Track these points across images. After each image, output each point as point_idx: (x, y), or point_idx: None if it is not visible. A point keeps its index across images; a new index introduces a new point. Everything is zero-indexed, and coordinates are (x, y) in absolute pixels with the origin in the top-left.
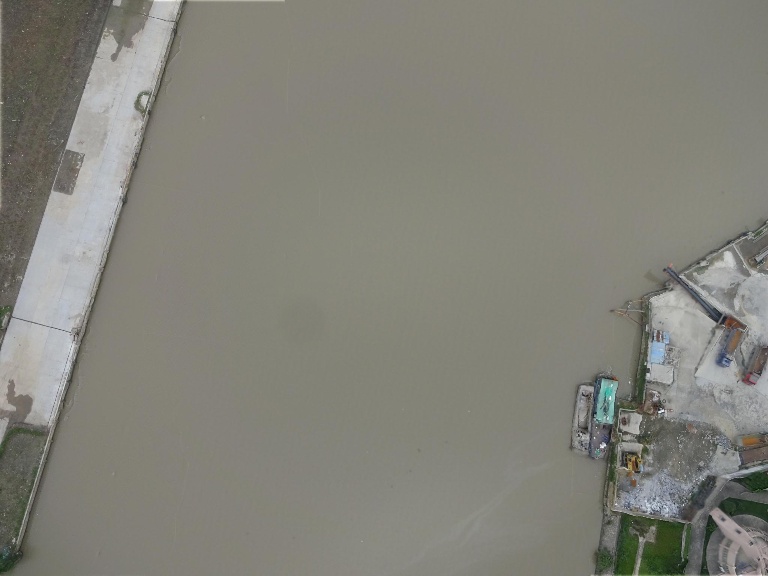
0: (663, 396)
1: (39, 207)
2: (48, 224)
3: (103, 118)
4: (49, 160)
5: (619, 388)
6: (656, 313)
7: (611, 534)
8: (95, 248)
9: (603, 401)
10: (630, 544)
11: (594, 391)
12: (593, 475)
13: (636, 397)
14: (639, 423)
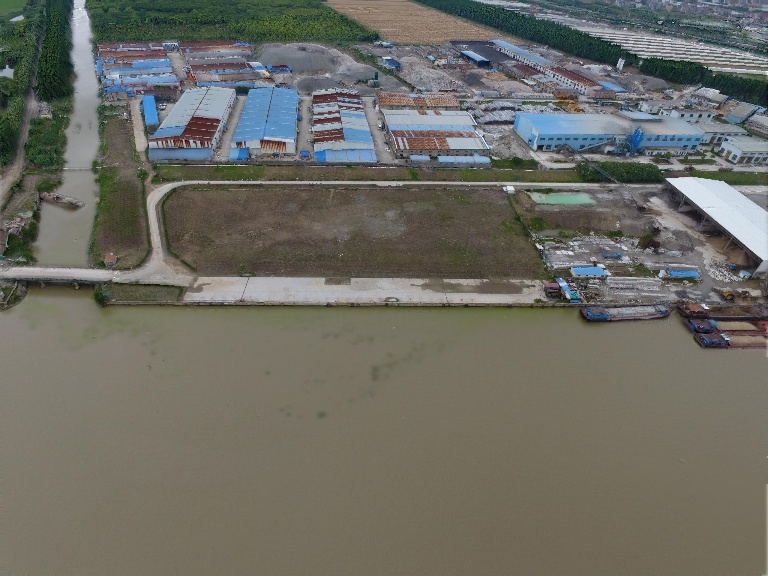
0: None
1: (314, 275)
2: (305, 280)
3: (375, 287)
4: (342, 273)
5: None
6: None
7: None
8: (295, 298)
9: None
10: None
11: None
12: None
13: None
14: None
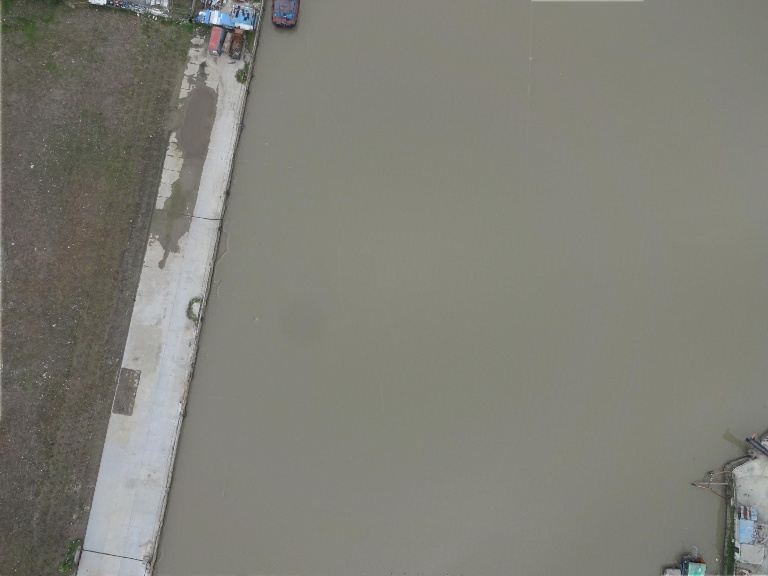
0: (754, 574)
1: (100, 432)
2: (110, 448)
3: (156, 331)
4: (106, 381)
5: (706, 567)
6: (740, 485)
7: None
8: (159, 469)
9: None
10: None
11: (681, 575)
12: None
13: None
14: None
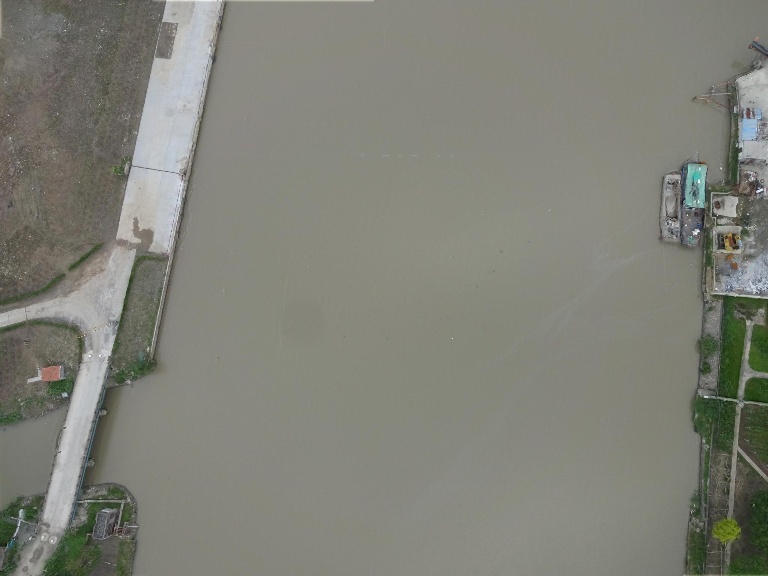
0: (761, 176)
1: (145, 73)
2: (154, 86)
3: None
4: (150, 33)
5: (709, 175)
6: (744, 93)
7: (714, 320)
8: (193, 100)
9: (691, 186)
10: (736, 327)
11: (681, 179)
12: (688, 263)
13: (729, 181)
14: (735, 206)
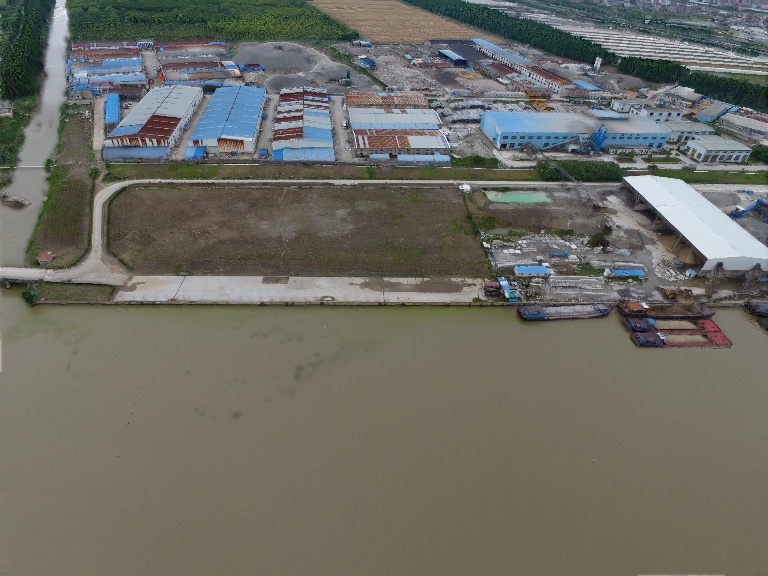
0: None
1: (253, 274)
2: (243, 279)
3: (312, 286)
4: (281, 272)
5: None
6: None
7: None
8: (229, 297)
9: None
10: None
11: None
12: None
13: None
14: None
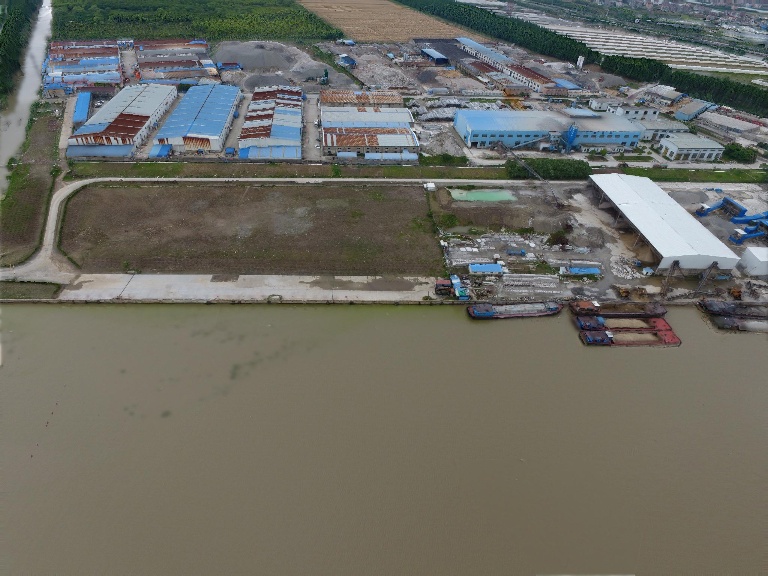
0: None
1: (202, 272)
2: (192, 277)
3: (261, 285)
4: (232, 271)
5: None
6: None
7: None
8: (175, 296)
9: None
10: None
11: None
12: None
13: None
14: None
